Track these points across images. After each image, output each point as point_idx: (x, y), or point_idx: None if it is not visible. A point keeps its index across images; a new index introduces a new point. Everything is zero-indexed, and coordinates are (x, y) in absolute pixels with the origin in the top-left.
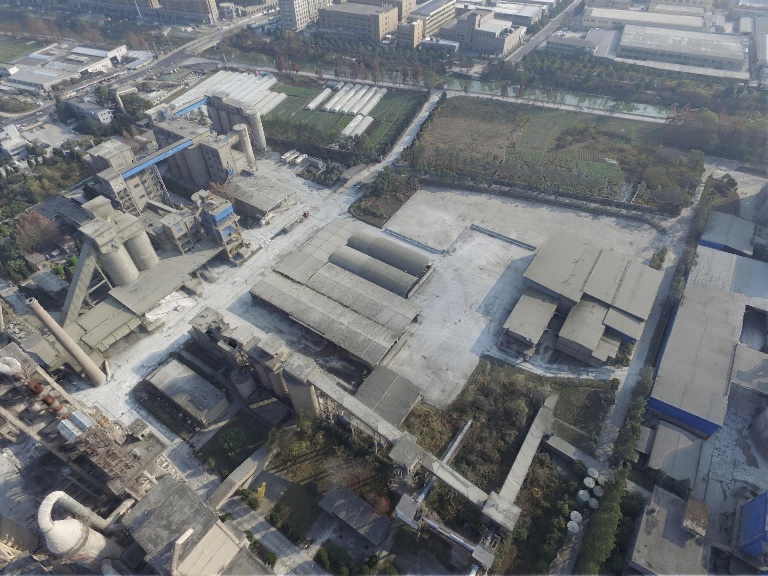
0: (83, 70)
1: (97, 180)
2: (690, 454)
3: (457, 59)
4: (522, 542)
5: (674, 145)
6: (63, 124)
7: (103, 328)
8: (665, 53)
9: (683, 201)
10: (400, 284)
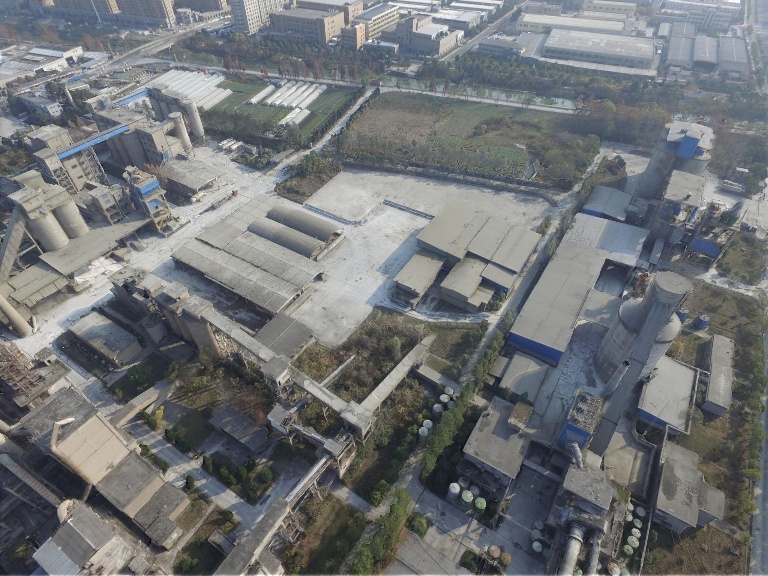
0: (38, 69)
1: (39, 163)
2: (536, 376)
3: (395, 59)
4: (383, 448)
5: (578, 132)
6: (15, 117)
7: (31, 286)
8: (584, 53)
9: (572, 177)
10: (308, 247)
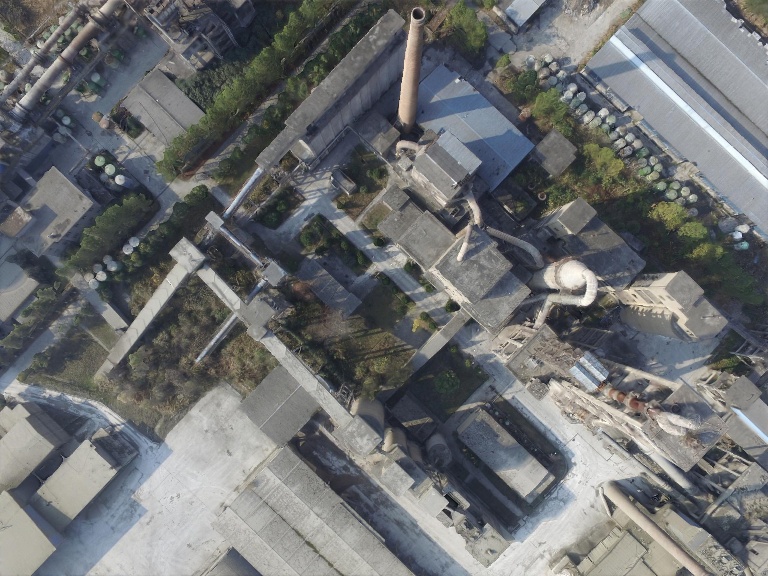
0: None
1: None
2: None
3: None
4: None
5: None
6: None
7: (623, 563)
8: None
9: None
10: (230, 570)
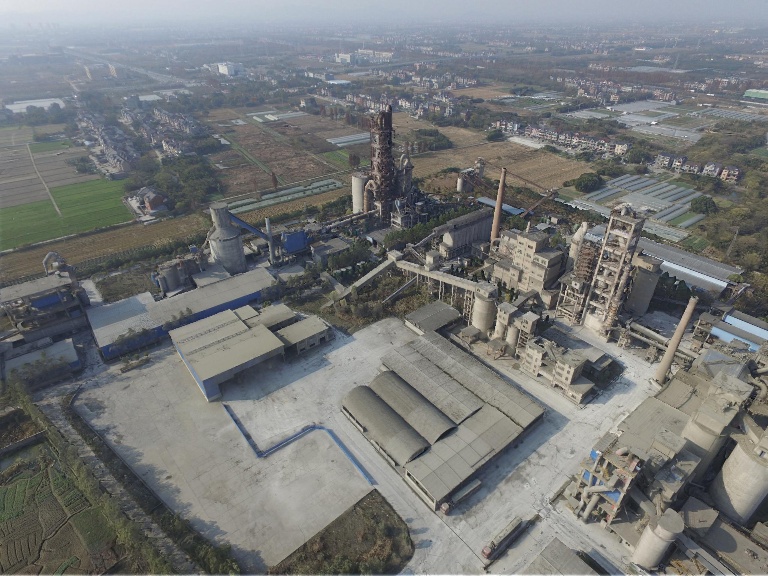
0: None
1: None
2: None
3: None
4: None
5: None
6: None
7: (680, 394)
8: None
9: None
10: (391, 375)
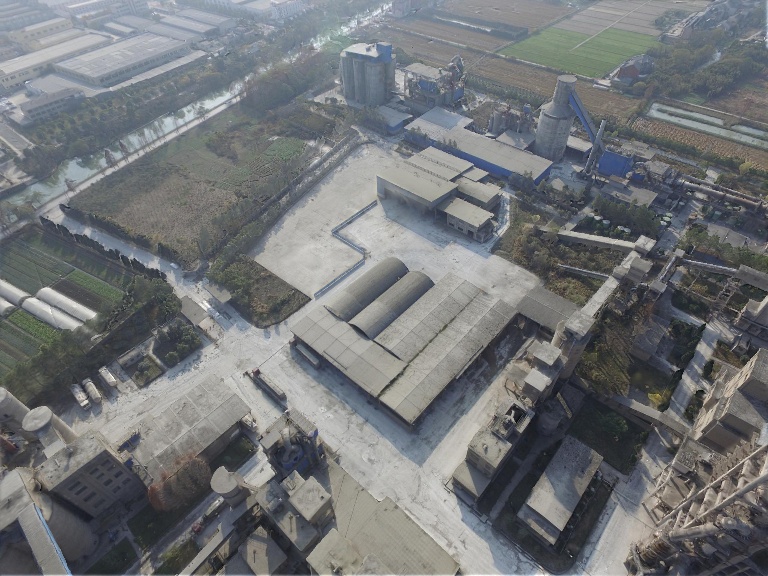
0: None
1: None
2: (566, 181)
3: None
4: None
5: (271, 107)
6: None
7: None
8: (135, 65)
9: None
10: (423, 281)
